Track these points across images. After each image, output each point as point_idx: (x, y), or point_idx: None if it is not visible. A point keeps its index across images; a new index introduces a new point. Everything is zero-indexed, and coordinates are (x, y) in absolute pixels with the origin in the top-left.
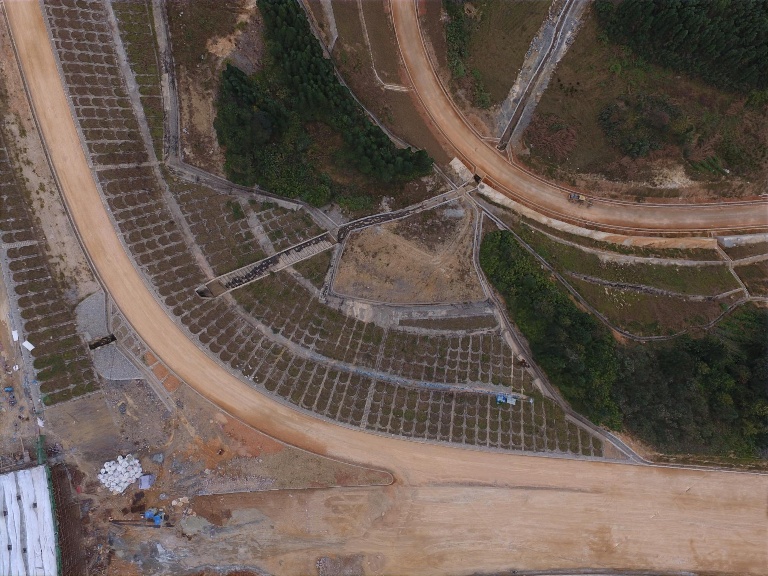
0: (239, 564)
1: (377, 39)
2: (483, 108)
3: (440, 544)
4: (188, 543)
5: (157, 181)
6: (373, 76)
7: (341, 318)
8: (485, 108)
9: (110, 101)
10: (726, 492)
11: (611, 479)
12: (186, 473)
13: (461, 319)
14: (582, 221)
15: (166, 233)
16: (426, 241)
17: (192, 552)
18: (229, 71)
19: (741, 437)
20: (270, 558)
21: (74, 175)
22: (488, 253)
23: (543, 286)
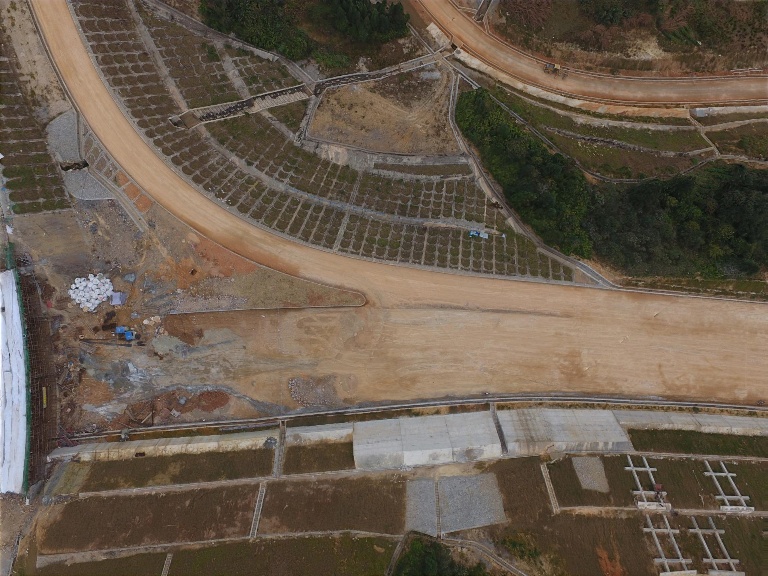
0: (211, 384)
1: None
2: None
3: (412, 366)
4: (160, 362)
5: (131, 13)
6: None
7: (316, 159)
8: None
9: None
10: (693, 318)
11: (581, 303)
12: (158, 292)
13: (436, 166)
14: (558, 91)
15: (139, 63)
16: (402, 99)
17: (164, 372)
18: None
19: (707, 259)
20: (242, 378)
21: None
22: (463, 108)
23: (517, 135)
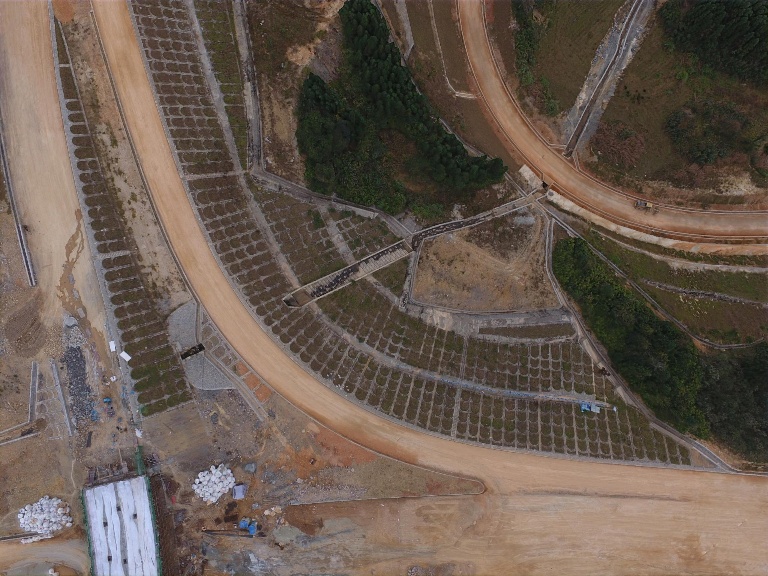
0: (331, 573)
1: (448, 47)
2: (551, 115)
3: (530, 553)
4: (280, 553)
5: (242, 190)
6: (445, 84)
7: (422, 326)
8: (553, 115)
9: (197, 110)
10: None
11: (699, 487)
12: (278, 483)
13: (539, 327)
14: (648, 228)
15: (253, 242)
16: (499, 249)
17: (284, 562)
18: (311, 80)
19: None
20: (362, 567)
21: (165, 185)
22: (562, 261)
23: (620, 294)
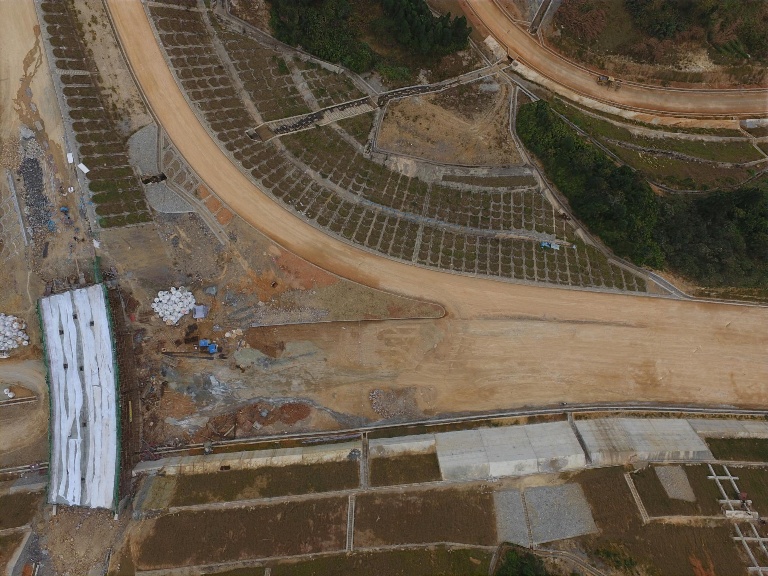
0: (292, 396)
1: None
2: None
3: (491, 377)
4: (241, 375)
5: (205, 27)
6: None
7: (386, 171)
8: None
9: None
10: (764, 327)
11: (655, 314)
12: (239, 305)
13: (502, 178)
14: (611, 103)
15: (216, 76)
16: (464, 111)
17: (245, 384)
18: None
19: None
20: (323, 390)
21: (126, 9)
22: (525, 120)
23: (580, 147)
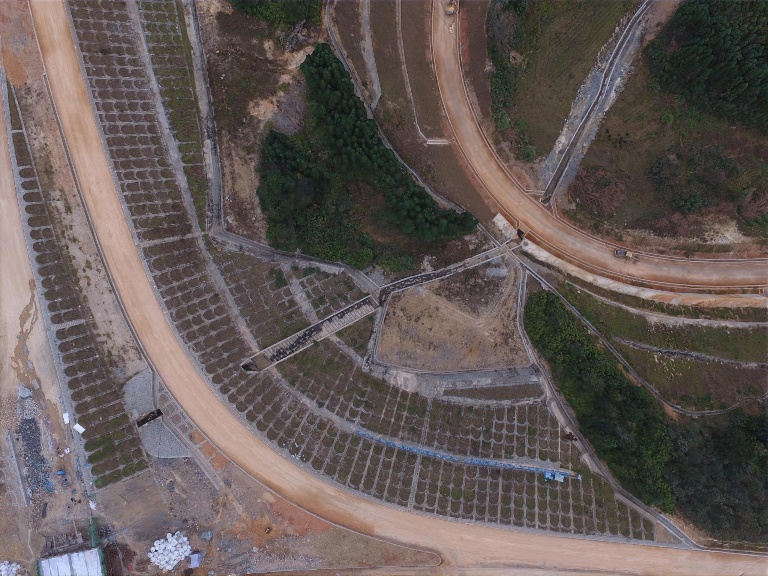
0: None
1: (420, 92)
2: (528, 161)
3: None
4: None
5: (201, 252)
6: (416, 132)
7: (385, 388)
8: (530, 162)
9: (154, 173)
10: None
11: (662, 563)
12: (234, 551)
13: (506, 388)
14: (628, 277)
15: (211, 307)
16: (469, 303)
17: None
18: (272, 137)
19: None
20: None
21: (120, 252)
22: (533, 317)
23: (591, 354)
